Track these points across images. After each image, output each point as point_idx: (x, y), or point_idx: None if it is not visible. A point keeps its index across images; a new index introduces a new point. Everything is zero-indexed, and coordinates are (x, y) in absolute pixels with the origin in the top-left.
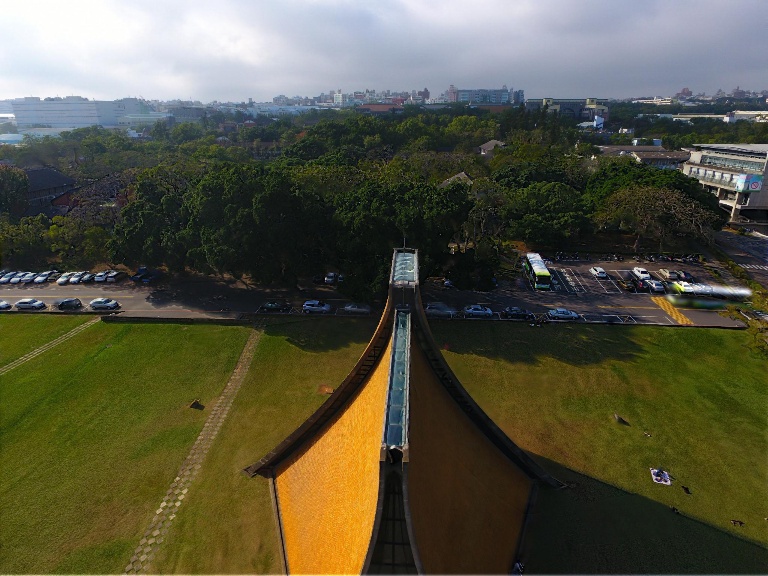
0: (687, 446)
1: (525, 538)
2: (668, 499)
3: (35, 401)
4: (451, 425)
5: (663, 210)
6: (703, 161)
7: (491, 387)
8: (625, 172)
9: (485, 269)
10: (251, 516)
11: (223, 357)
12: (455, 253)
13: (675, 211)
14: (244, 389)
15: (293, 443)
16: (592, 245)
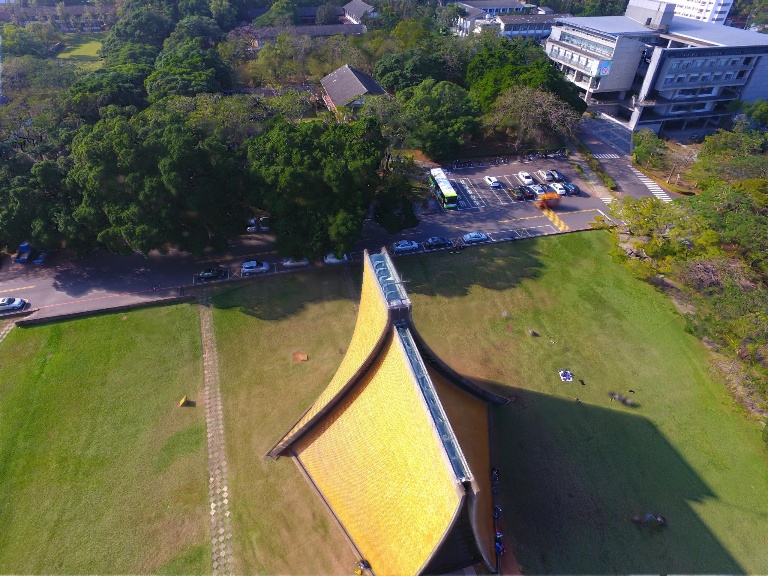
0: (578, 346)
1: (493, 450)
2: (573, 393)
3: (8, 441)
4: (441, 395)
5: (542, 117)
6: (562, 38)
7: (435, 323)
8: (500, 58)
9: (407, 205)
10: (294, 493)
11: (185, 344)
12: (378, 194)
13: (551, 117)
14: (224, 374)
15: (308, 428)
16: (480, 147)
